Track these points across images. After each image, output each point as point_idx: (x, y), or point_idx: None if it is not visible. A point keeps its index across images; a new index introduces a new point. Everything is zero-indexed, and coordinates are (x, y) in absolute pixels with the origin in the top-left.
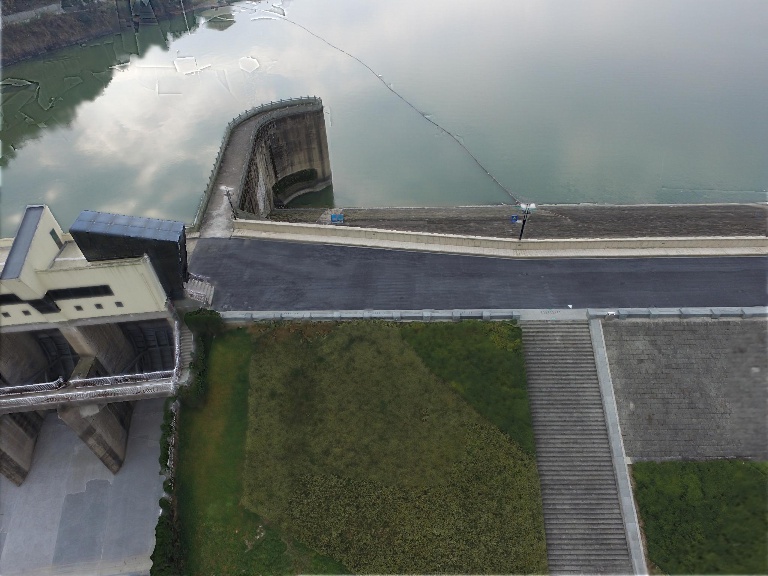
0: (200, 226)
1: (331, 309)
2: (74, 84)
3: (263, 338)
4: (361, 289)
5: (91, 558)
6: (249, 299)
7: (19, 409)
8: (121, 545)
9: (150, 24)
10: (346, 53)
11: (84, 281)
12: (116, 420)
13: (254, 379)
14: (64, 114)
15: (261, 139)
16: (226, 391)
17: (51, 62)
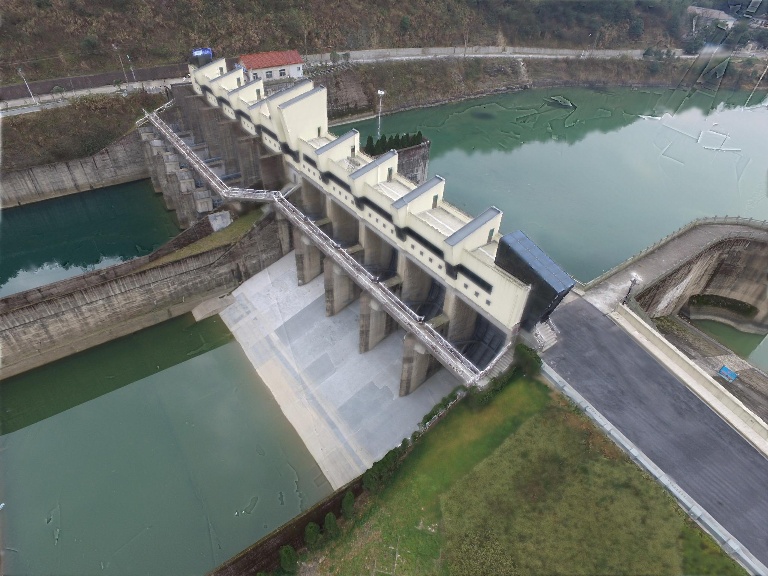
0: (590, 288)
1: (634, 443)
2: (602, 116)
3: (556, 410)
4: (683, 455)
5: (352, 427)
6: (574, 372)
7: (393, 316)
8: (368, 438)
9: (707, 94)
10: None
11: (482, 273)
12: (427, 367)
13: (523, 430)
14: (577, 134)
15: (719, 249)
16: (498, 418)
17: (599, 94)
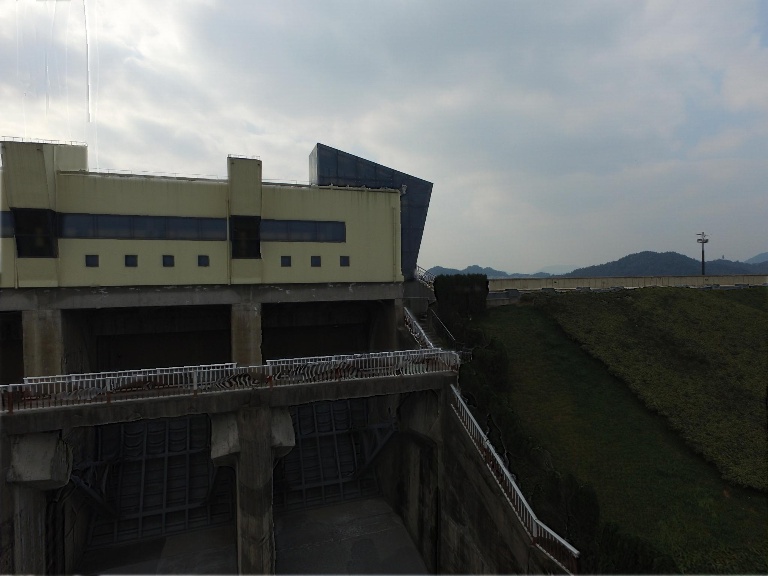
0: None
1: None
2: None
3: (553, 300)
4: None
5: None
6: None
7: (161, 406)
8: None
9: None
10: None
11: (316, 211)
12: None
13: (580, 333)
14: None
15: None
16: (537, 363)
17: None
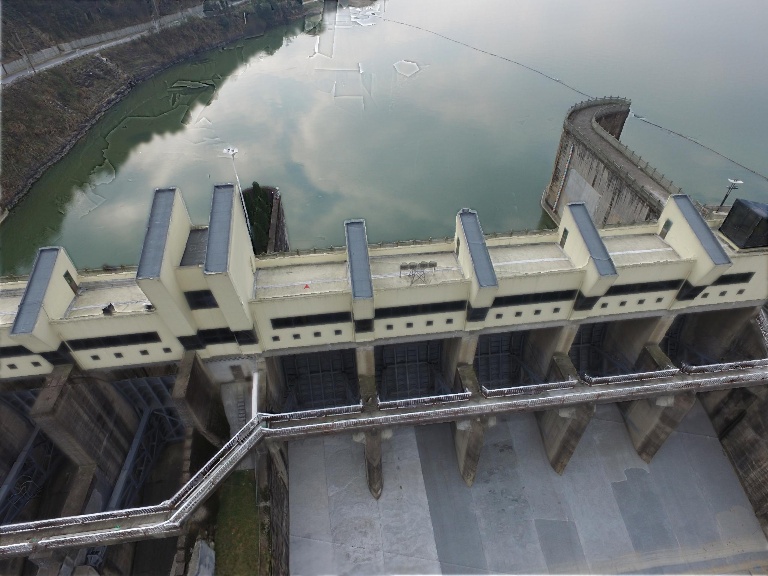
0: None
1: None
2: None
3: None
4: None
5: (670, 545)
6: None
7: (651, 395)
8: (692, 532)
9: (343, 27)
10: (501, 58)
11: (740, 268)
12: None
13: None
14: (185, 117)
15: None
16: None
17: (196, 65)
